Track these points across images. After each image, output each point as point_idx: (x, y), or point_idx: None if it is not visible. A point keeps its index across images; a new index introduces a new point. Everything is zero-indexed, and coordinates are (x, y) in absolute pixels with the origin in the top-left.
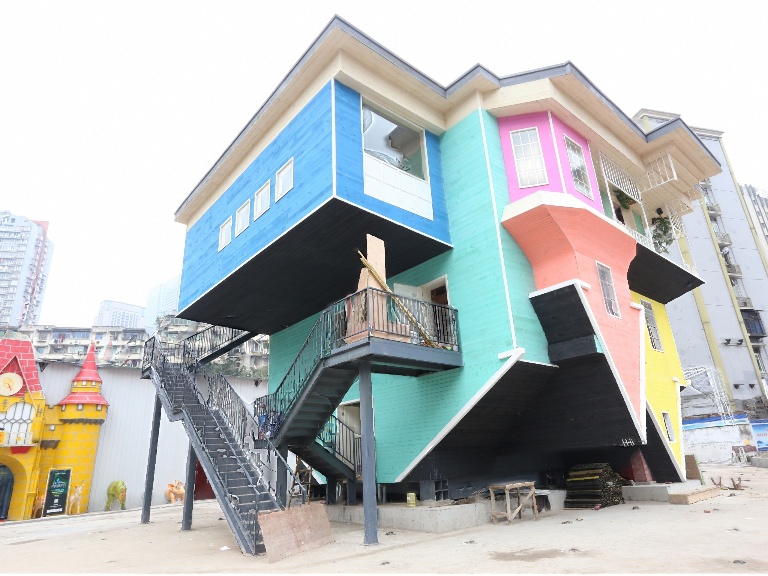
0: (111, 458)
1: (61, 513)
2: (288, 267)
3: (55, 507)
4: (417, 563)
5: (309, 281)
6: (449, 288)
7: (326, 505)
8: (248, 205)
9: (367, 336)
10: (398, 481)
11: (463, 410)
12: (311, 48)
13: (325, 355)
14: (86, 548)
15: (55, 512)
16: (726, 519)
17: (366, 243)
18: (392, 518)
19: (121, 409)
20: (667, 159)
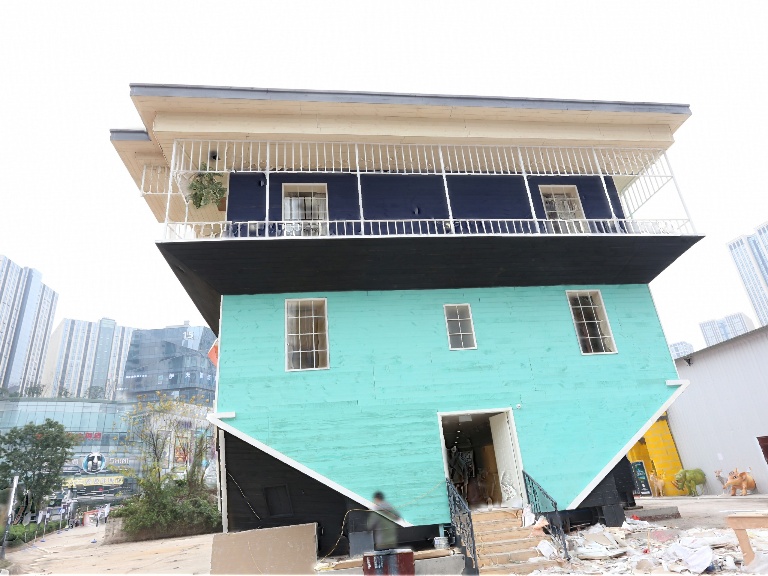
0: (687, 447)
1: (649, 495)
2: None
3: (645, 490)
4: None
5: None
6: None
7: None
8: None
9: None
10: None
11: None
12: None
13: None
14: None
15: (646, 494)
16: (181, 573)
17: None
18: None
19: (675, 402)
20: (176, 220)
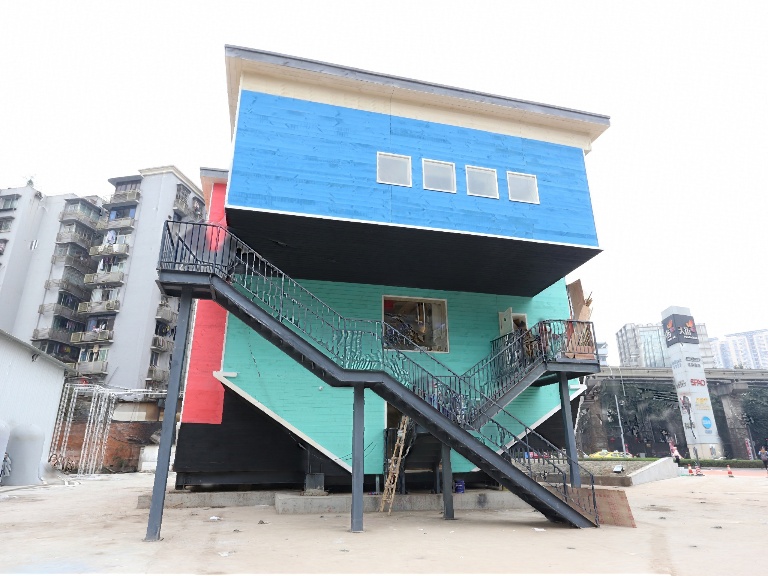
0: None
1: None
2: (466, 253)
3: None
4: (666, 516)
5: (437, 266)
6: (528, 325)
7: (405, 495)
8: (442, 165)
9: (596, 359)
10: (477, 470)
11: (544, 419)
12: (579, 113)
13: (548, 360)
14: (443, 553)
15: None
16: None
17: (531, 272)
18: (503, 500)
19: None
20: None
